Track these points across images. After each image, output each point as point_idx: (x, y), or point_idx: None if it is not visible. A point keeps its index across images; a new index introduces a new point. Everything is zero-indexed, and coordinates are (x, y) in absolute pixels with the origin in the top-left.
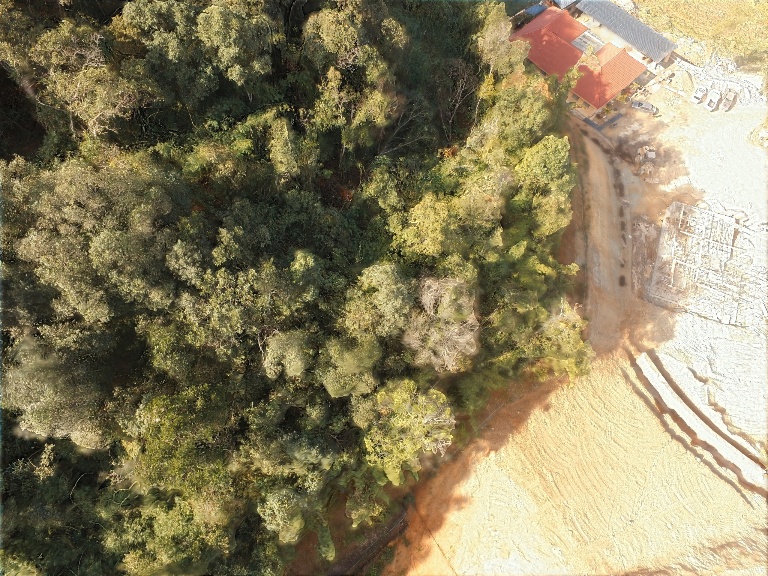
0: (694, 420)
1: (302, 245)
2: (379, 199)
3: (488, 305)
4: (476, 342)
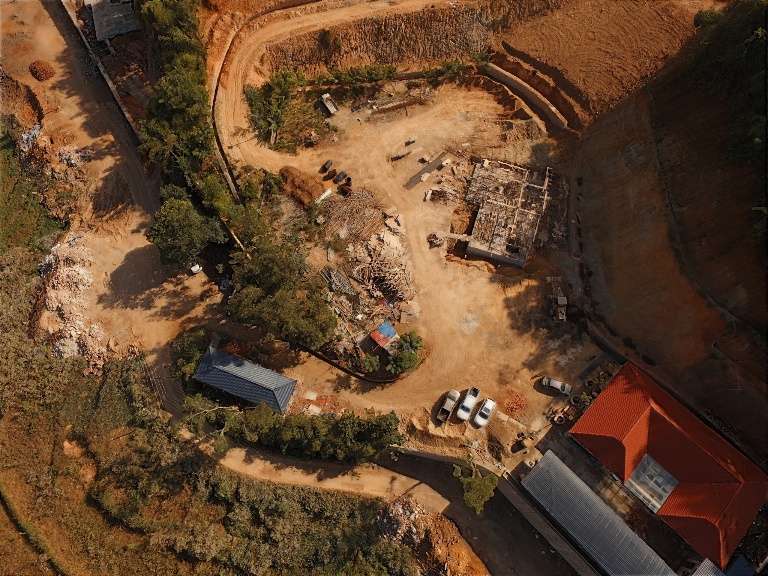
0: (531, 87)
1: None
2: None
3: None
4: None
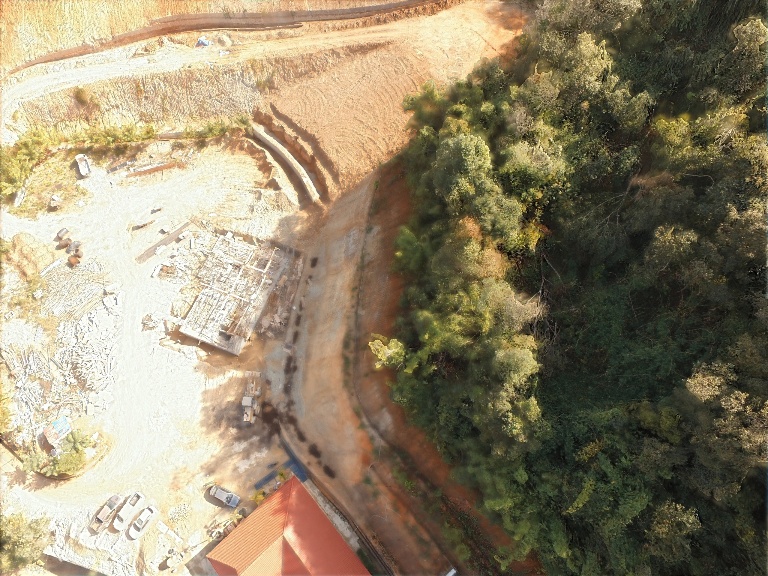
0: (289, 154)
1: (691, 39)
2: (631, 96)
3: (506, 82)
4: (513, 62)
